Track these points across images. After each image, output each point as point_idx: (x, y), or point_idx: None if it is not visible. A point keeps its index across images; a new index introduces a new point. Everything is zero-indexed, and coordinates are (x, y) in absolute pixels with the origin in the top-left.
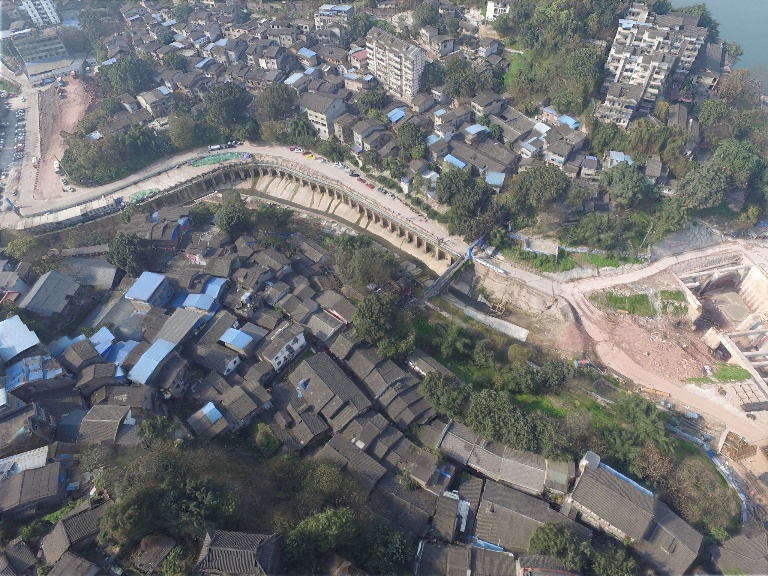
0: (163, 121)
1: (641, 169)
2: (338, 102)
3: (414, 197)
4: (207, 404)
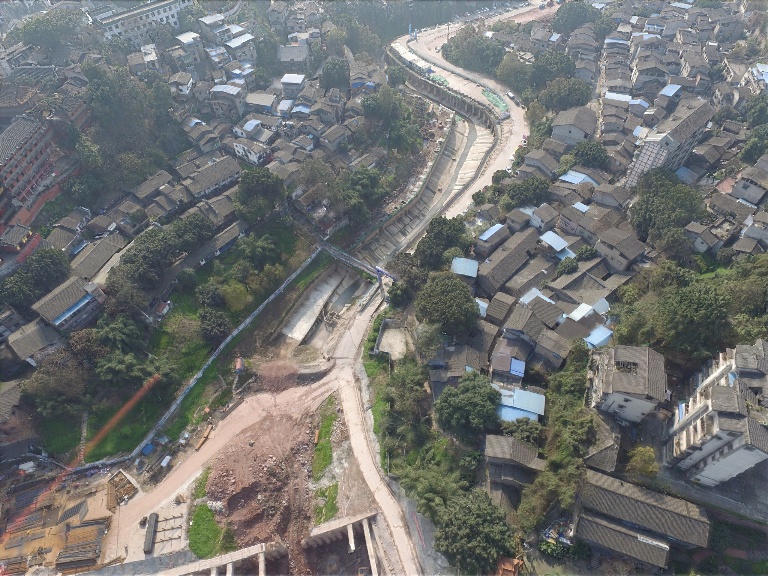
0: (526, 56)
1: (497, 429)
2: (578, 131)
3: None
4: (205, 123)
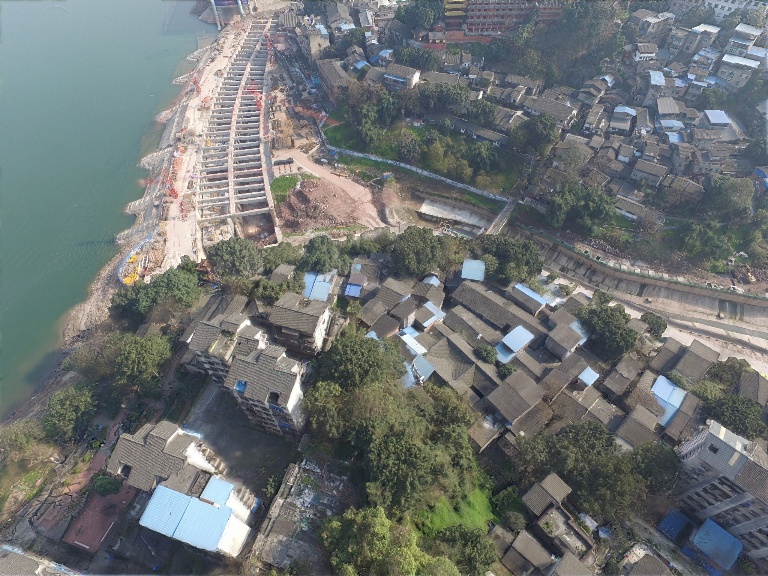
0: None
1: None
2: None
3: (563, 285)
4: None
